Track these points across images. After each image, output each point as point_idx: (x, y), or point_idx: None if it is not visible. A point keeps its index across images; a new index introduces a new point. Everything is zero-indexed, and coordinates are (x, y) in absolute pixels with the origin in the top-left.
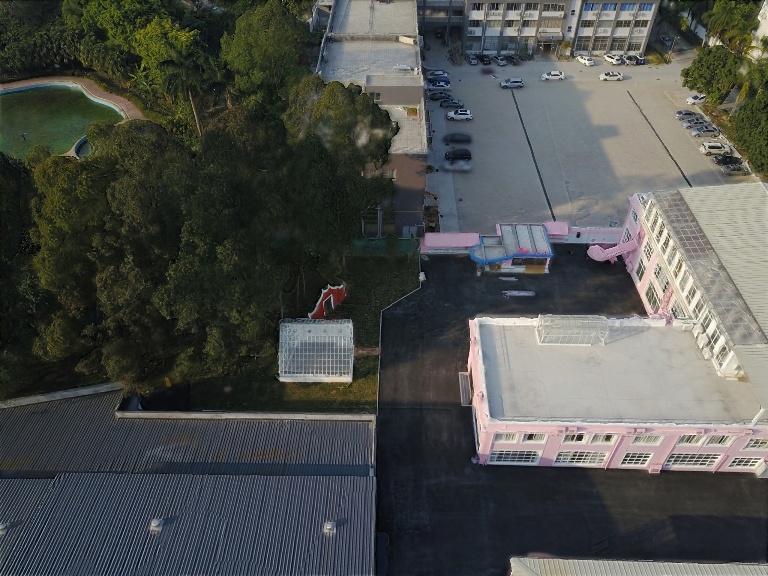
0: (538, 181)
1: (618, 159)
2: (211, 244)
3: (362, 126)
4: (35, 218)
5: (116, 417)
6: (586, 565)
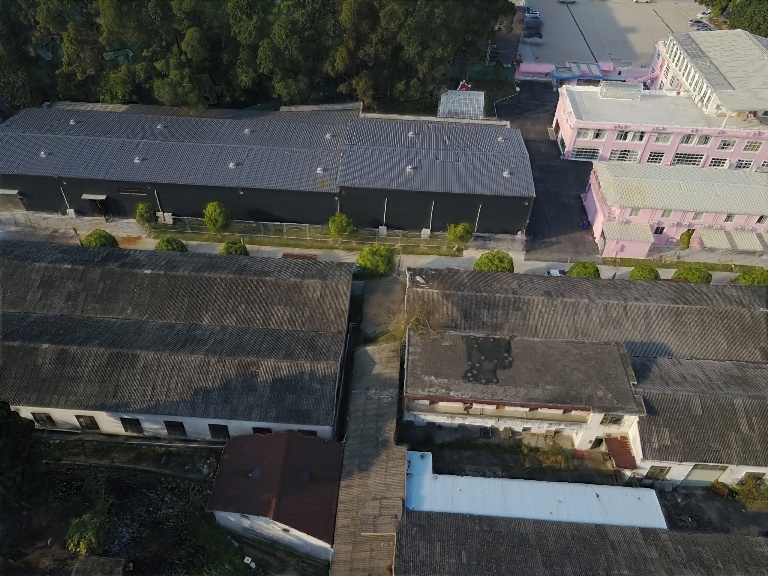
0: (590, 52)
1: (646, 44)
2: (432, 8)
3: None
4: None
5: (360, 117)
6: (631, 164)
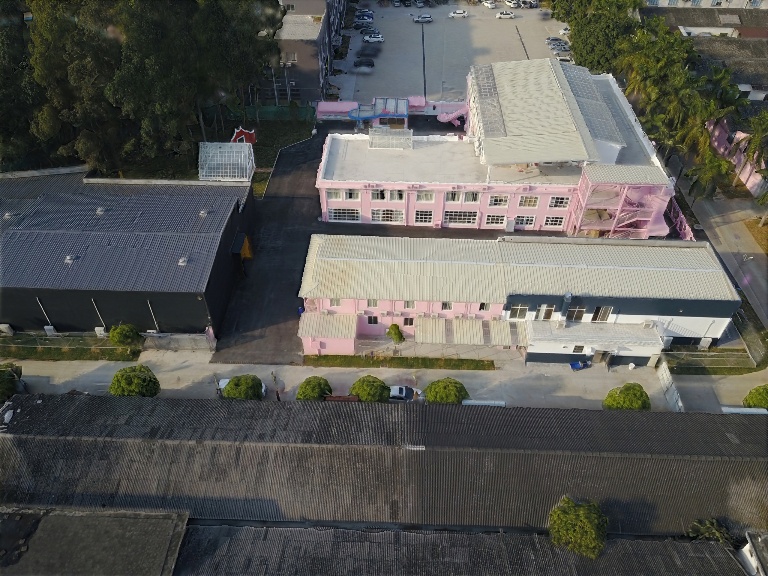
0: (422, 81)
1: None
2: (142, 58)
3: (254, 2)
4: (32, 36)
5: (83, 183)
6: (355, 237)
